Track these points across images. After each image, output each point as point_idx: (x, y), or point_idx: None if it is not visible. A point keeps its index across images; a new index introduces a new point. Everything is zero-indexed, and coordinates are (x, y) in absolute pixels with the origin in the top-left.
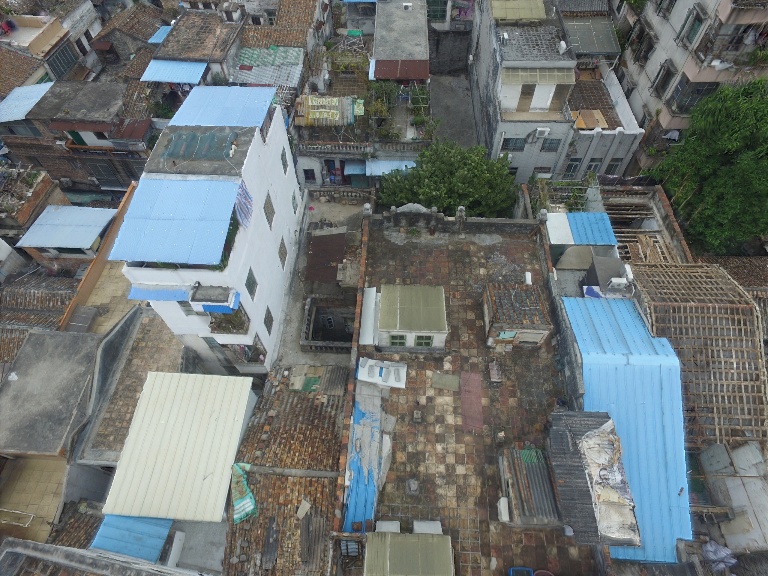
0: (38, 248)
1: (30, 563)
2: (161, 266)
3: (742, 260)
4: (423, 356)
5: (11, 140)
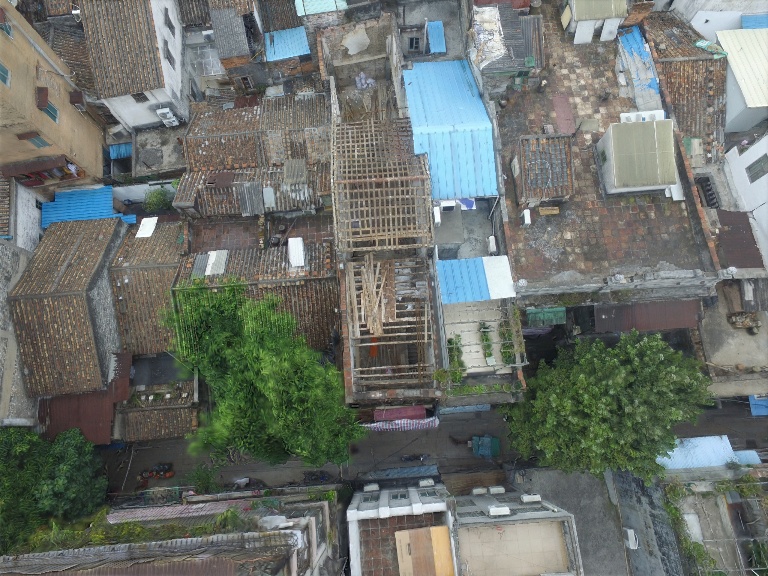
0: None
1: None
2: None
3: None
4: None
5: None
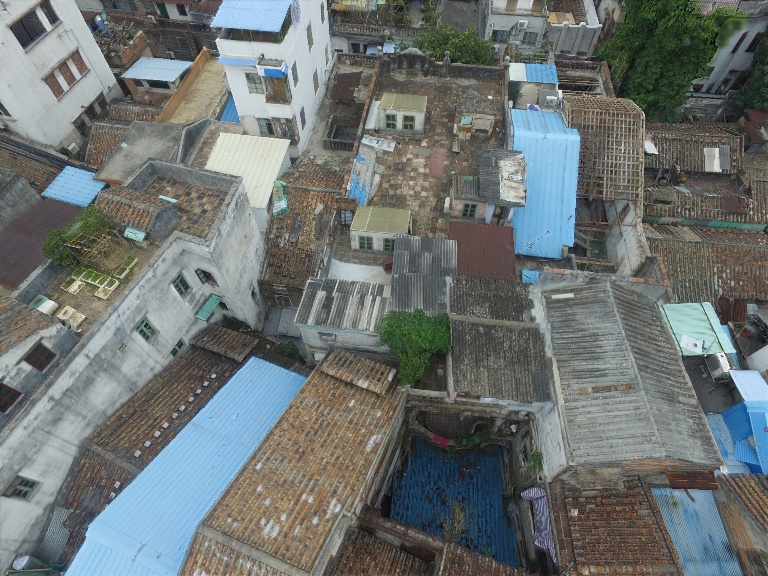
0: (136, 80)
1: (160, 179)
2: (242, 33)
3: (665, 124)
4: (408, 138)
5: (113, 14)
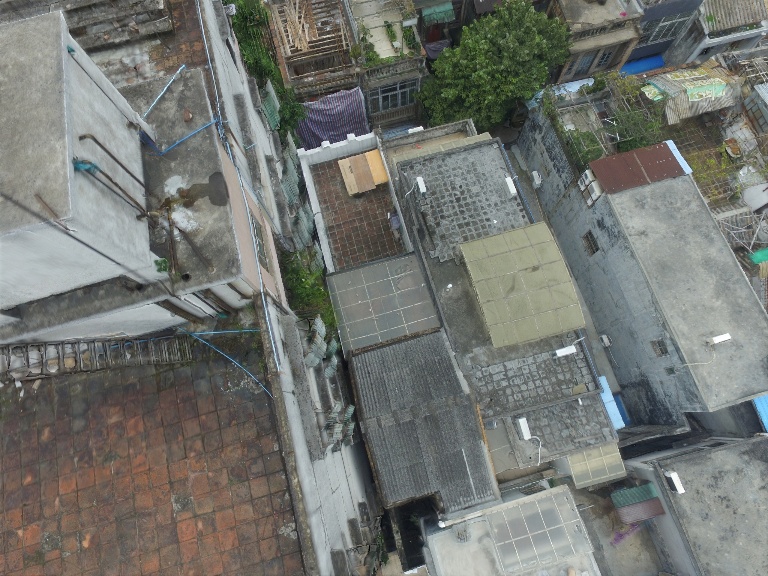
0: None
1: None
2: None
3: None
4: None
5: None
